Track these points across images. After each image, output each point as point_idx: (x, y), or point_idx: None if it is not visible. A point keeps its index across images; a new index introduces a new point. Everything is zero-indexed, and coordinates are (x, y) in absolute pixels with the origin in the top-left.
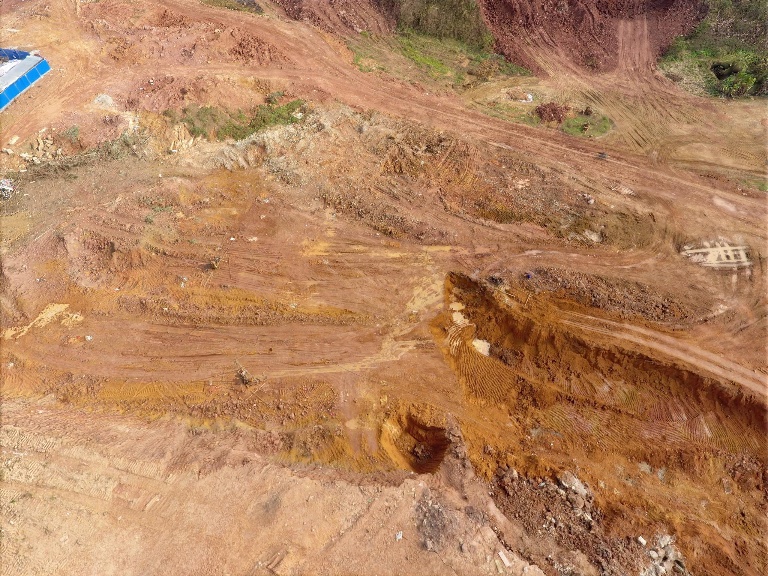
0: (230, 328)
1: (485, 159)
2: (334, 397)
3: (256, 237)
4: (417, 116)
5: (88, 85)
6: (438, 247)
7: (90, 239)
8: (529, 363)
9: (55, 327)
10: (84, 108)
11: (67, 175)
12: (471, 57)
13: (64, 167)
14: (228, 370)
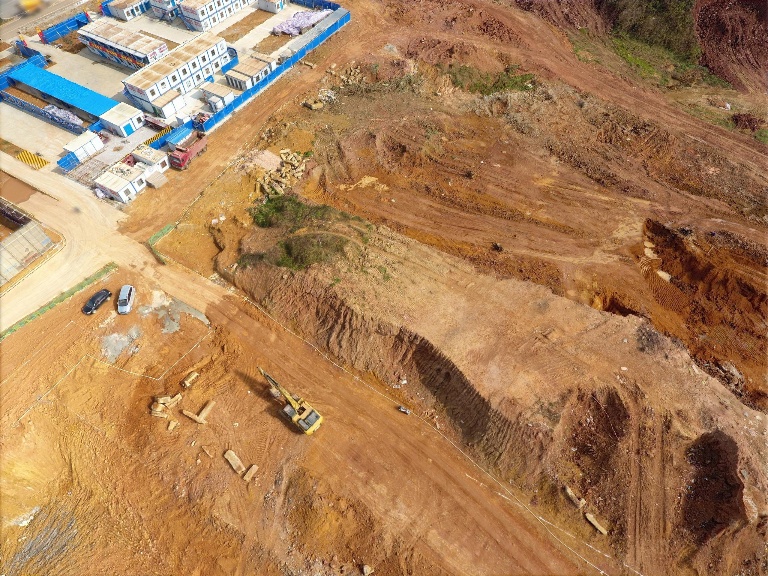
0: (487, 216)
1: (682, 146)
2: (559, 274)
3: (499, 164)
4: (626, 103)
5: (378, 36)
6: (640, 200)
7: (388, 141)
8: (701, 296)
9: (371, 190)
10: (378, 52)
11: (368, 96)
12: (677, 64)
13: (367, 90)
14: (486, 241)
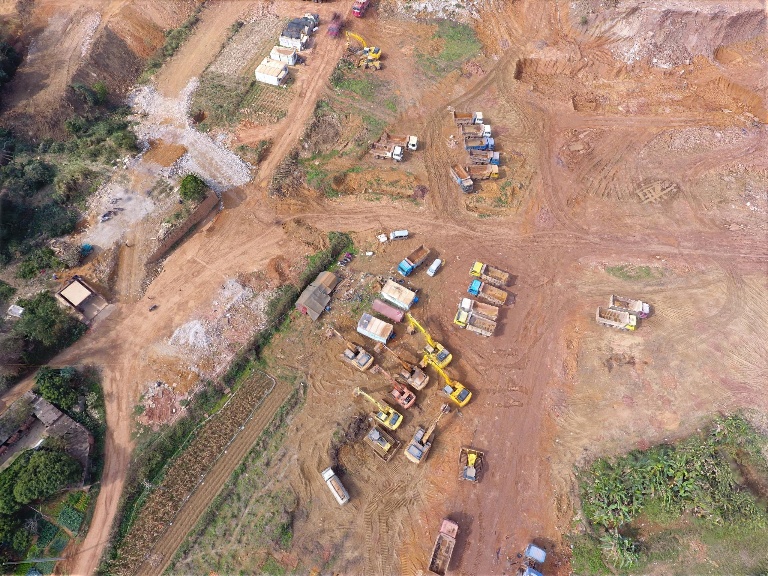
0: None
1: None
2: None
3: None
4: None
5: None
6: None
7: None
8: None
9: None
10: None
11: None
12: None
13: None
14: None
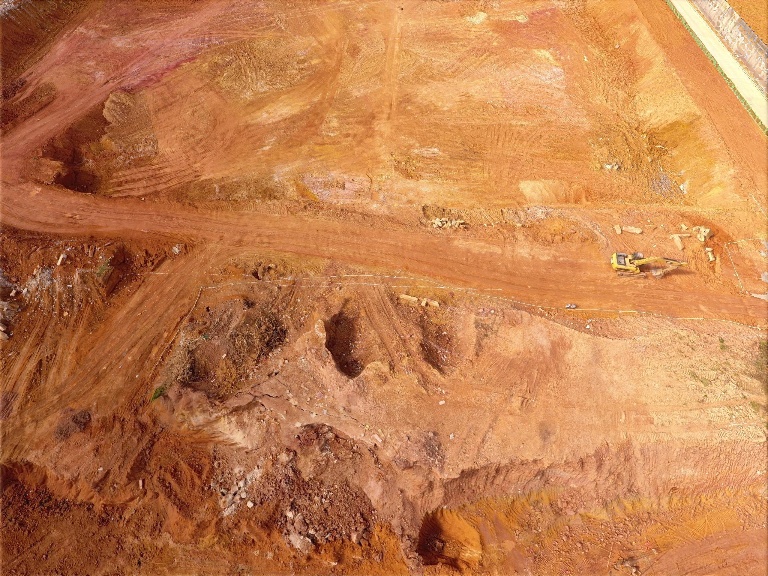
0: None
1: None
2: (537, 571)
3: None
4: None
5: None
6: None
7: None
8: None
9: None
10: None
11: None
12: None
13: None
14: (650, 572)
